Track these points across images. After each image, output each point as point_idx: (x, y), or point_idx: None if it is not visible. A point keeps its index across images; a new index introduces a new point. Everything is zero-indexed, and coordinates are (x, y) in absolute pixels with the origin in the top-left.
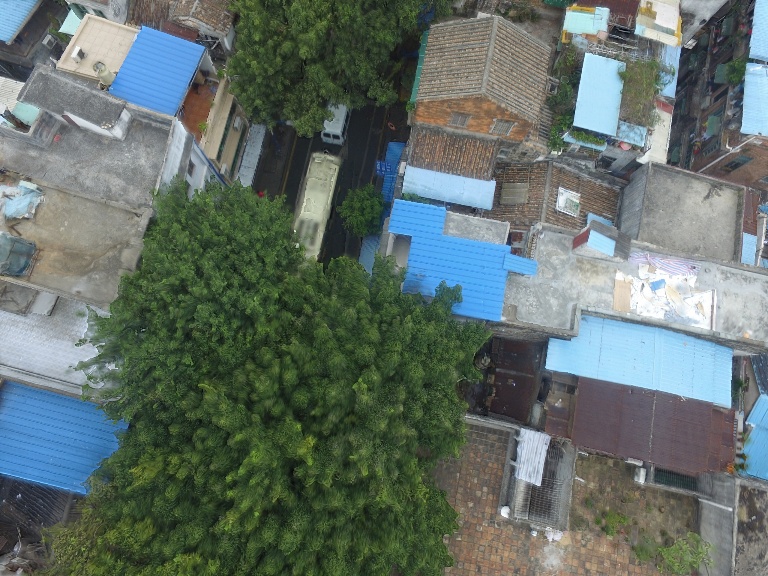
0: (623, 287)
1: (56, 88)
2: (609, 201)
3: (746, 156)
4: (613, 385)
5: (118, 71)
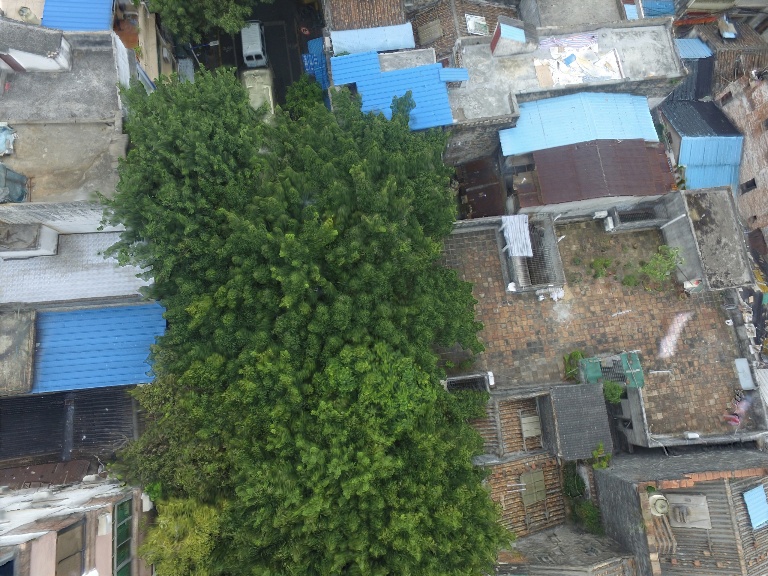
0: (543, 70)
1: None
2: None
3: None
4: (561, 148)
5: (42, 17)
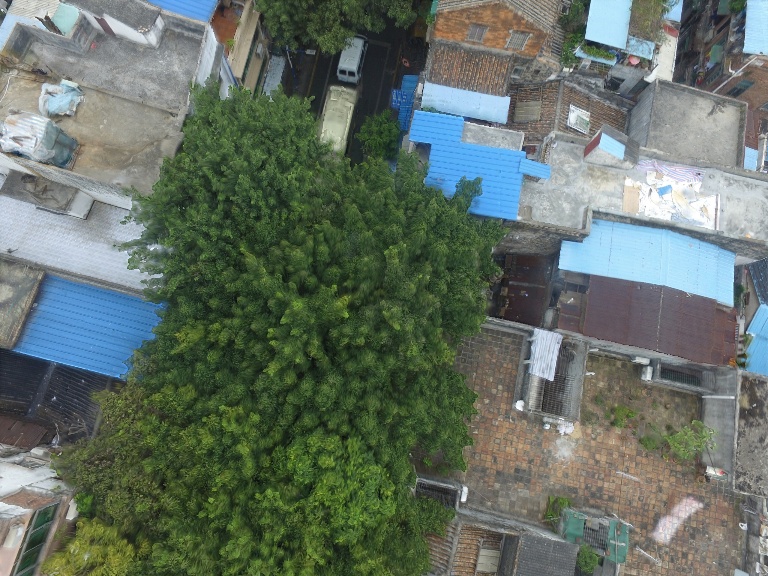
0: (632, 192)
1: None
2: (617, 122)
3: (748, 80)
4: (623, 282)
5: None
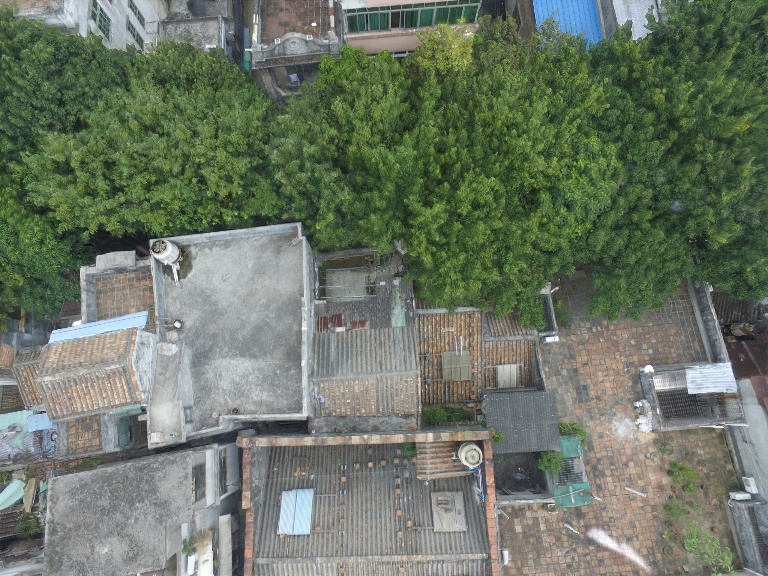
0: None
1: None
2: None
3: None
4: None
5: None
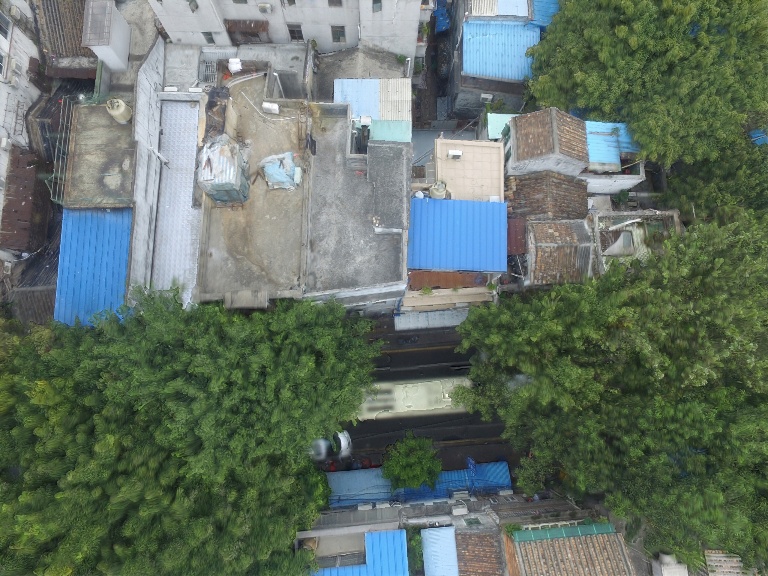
0: None
1: (393, 168)
2: None
3: None
4: None
5: None
